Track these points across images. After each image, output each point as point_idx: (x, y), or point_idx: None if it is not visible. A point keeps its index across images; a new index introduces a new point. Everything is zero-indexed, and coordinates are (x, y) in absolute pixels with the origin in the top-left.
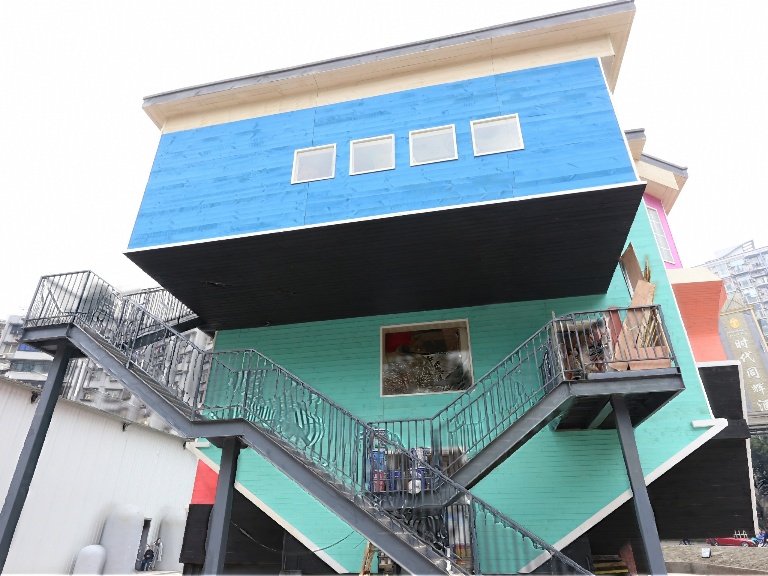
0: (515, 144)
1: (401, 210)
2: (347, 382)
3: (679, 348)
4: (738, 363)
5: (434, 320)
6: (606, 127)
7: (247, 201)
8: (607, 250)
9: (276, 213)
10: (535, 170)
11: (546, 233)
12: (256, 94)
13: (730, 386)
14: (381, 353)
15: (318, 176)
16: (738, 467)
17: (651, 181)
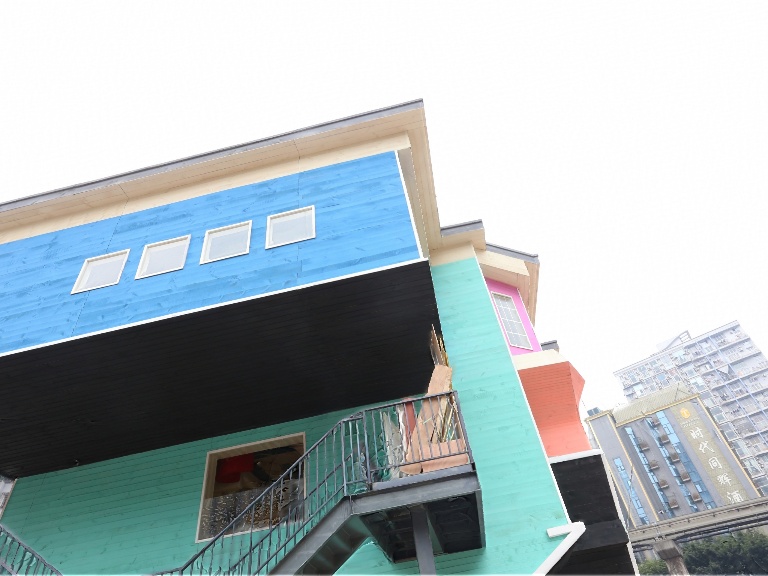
0: (308, 234)
1: (177, 311)
2: (158, 527)
3: (529, 441)
4: (600, 452)
5: (268, 437)
6: (396, 211)
7: (17, 317)
8: (426, 337)
9: (44, 327)
10: (323, 257)
11: (349, 324)
12: (62, 208)
13: (597, 480)
14: (203, 485)
15: (102, 283)
16: None
17: (499, 269)
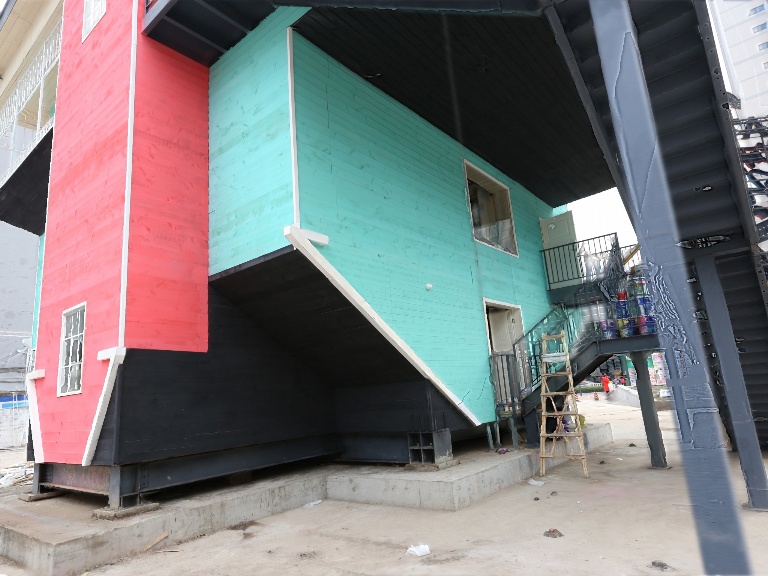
0: None
1: None
2: (450, 210)
3: None
4: None
5: None
6: None
7: None
8: None
9: None
10: None
11: None
12: None
13: None
14: None
15: None
16: None
17: None
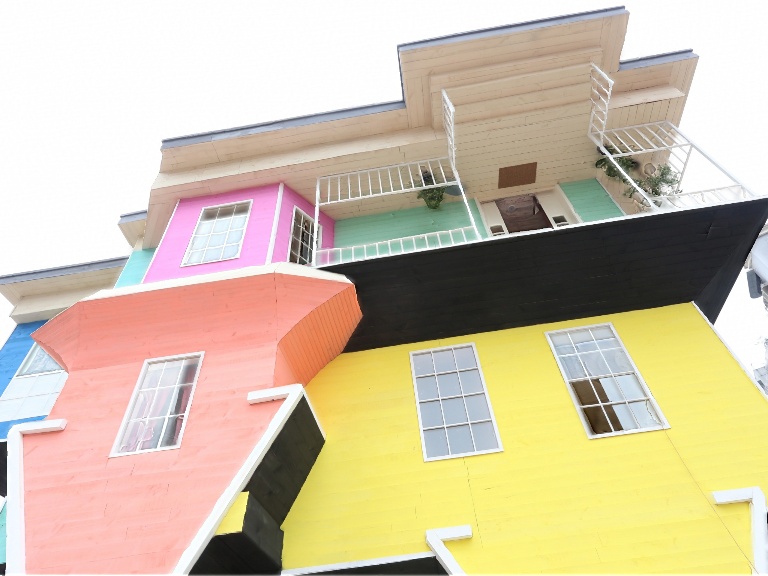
0: None
1: None
2: None
3: None
4: None
5: None
6: None
7: None
8: None
9: None
10: None
11: None
12: None
13: None
14: None
15: None
16: None
17: (147, 227)
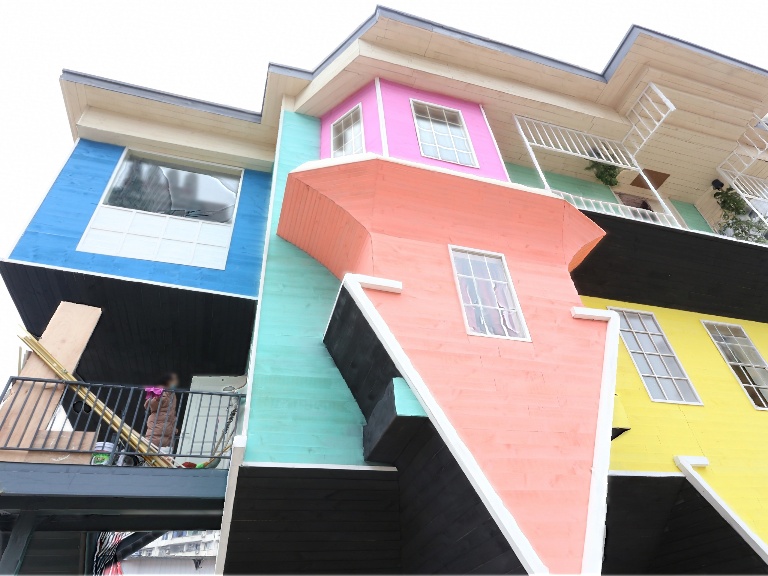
0: None
1: None
2: None
3: None
4: None
5: None
6: None
7: None
8: (137, 294)
9: None
10: None
11: None
12: None
13: (359, 328)
14: None
15: None
16: (455, 483)
17: (321, 90)
